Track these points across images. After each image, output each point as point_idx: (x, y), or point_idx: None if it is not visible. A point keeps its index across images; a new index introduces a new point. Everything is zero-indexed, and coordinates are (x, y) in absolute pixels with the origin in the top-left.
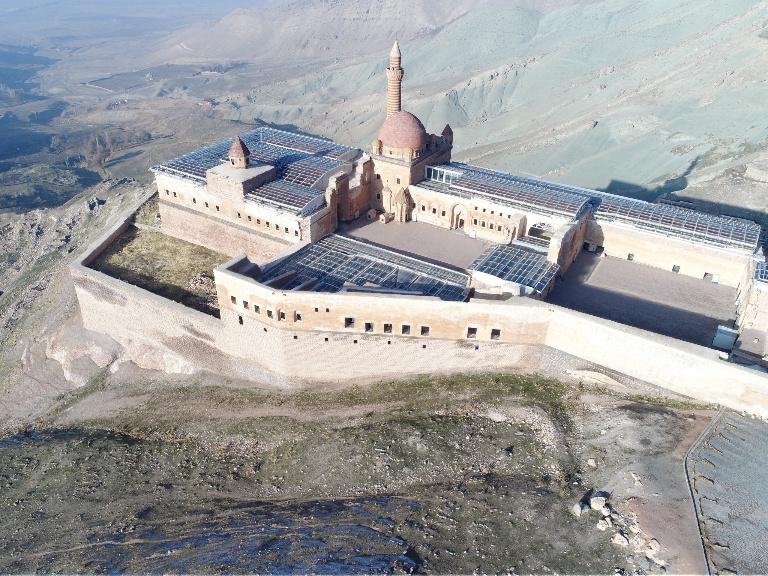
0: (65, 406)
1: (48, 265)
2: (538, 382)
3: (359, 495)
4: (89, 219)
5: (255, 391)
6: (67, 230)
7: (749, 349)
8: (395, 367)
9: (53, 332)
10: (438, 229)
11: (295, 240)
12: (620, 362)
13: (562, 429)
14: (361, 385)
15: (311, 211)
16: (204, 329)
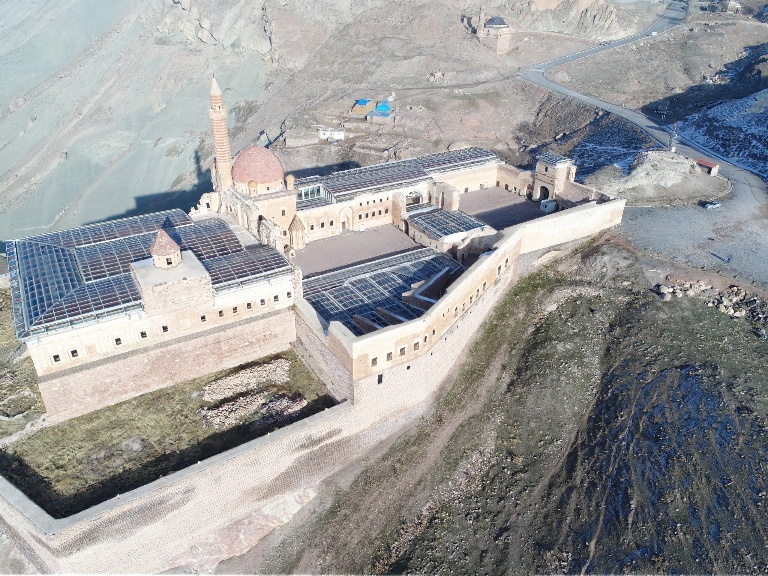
0: None
1: None
2: (529, 280)
3: (597, 391)
4: None
5: (404, 439)
6: None
7: (575, 200)
8: (471, 331)
9: None
10: (332, 239)
11: (289, 303)
12: (560, 237)
13: (587, 285)
14: (464, 362)
15: None
16: (329, 428)
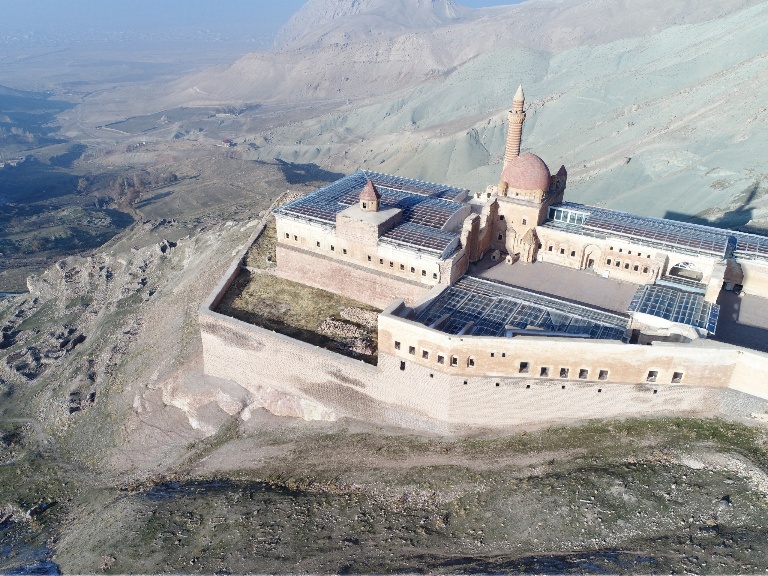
0: (199, 456)
1: (132, 309)
2: (722, 426)
3: (579, 550)
4: (162, 262)
5: (412, 438)
6: (141, 273)
7: None
8: (565, 412)
9: (168, 378)
10: (566, 269)
11: (433, 283)
12: None
13: None
14: (529, 431)
15: (449, 253)
16: (355, 375)
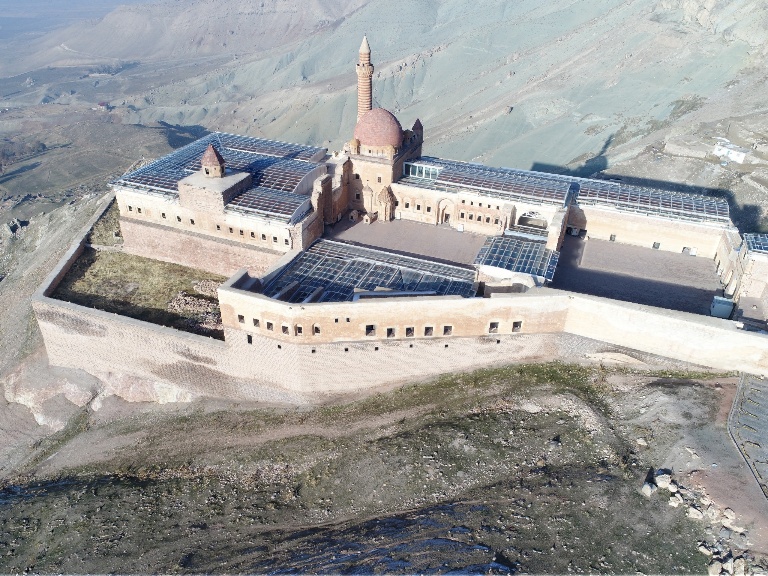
0: (46, 454)
1: None
2: (560, 369)
3: (419, 506)
4: (13, 243)
5: (269, 412)
6: None
7: (751, 316)
8: (416, 370)
9: (10, 373)
10: (424, 225)
11: (285, 249)
12: (641, 341)
13: (601, 412)
14: (383, 392)
15: (299, 217)
16: (204, 353)
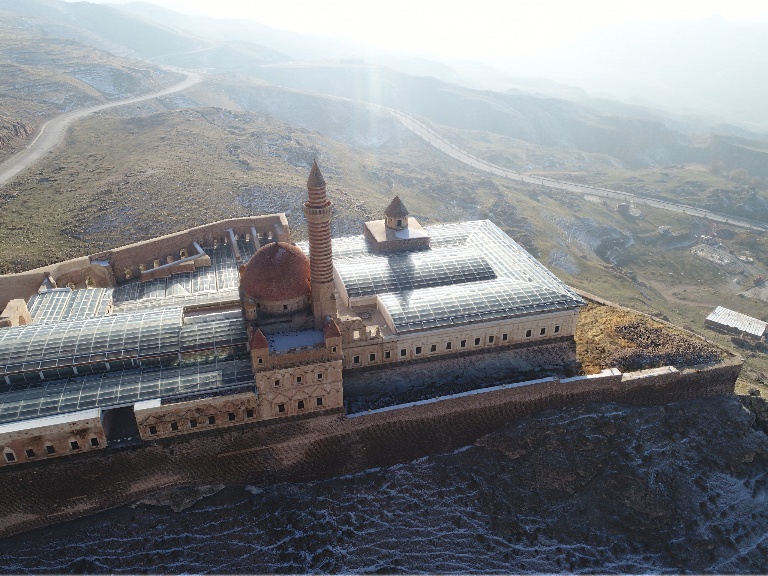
0: None
1: None
2: None
3: None
4: None
5: None
6: None
7: None
8: None
9: None
10: None
11: None
12: None
13: None
14: None
15: None
16: None
